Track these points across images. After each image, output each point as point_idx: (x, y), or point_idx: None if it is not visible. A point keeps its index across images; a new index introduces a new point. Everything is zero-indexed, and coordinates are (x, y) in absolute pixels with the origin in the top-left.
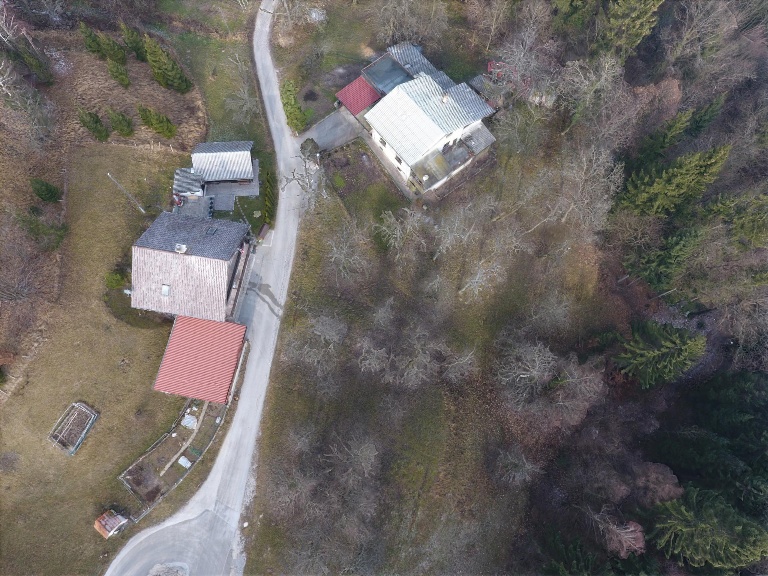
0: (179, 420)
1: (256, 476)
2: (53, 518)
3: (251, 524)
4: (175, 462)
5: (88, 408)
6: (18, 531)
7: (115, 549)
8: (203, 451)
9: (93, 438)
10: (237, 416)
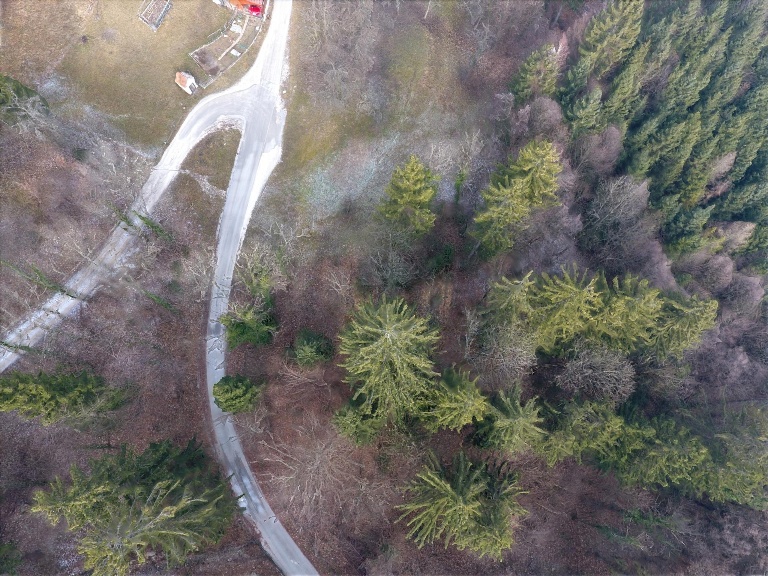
0: (228, 27)
1: (289, 63)
2: (145, 76)
3: (288, 91)
4: (228, 52)
5: (163, 1)
6: (121, 82)
7: (190, 105)
8: (248, 46)
9: (169, 22)
10: (271, 29)
